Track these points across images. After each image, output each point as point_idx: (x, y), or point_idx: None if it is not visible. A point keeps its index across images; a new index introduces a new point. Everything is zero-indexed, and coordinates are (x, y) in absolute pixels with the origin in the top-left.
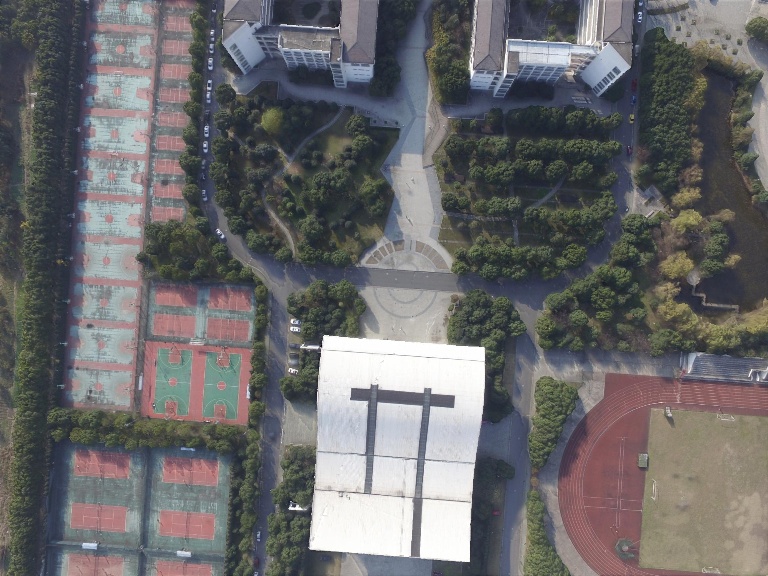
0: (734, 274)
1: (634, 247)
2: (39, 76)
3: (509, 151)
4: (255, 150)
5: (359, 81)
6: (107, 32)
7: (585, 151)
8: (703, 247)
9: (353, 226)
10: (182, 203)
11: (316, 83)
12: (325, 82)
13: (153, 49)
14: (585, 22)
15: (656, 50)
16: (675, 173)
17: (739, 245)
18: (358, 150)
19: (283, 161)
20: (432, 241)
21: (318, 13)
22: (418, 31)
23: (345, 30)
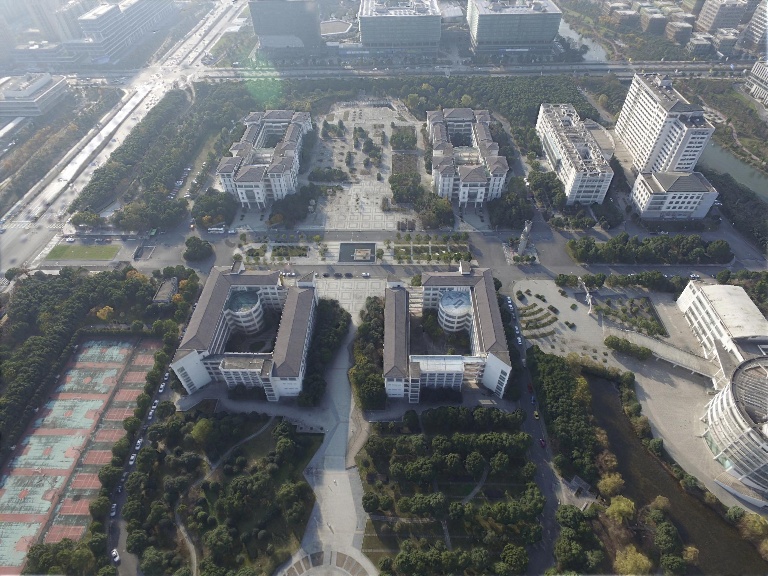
0: (706, 575)
1: (576, 543)
2: (2, 401)
3: (427, 447)
4: (179, 458)
5: (290, 395)
6: (82, 368)
7: (496, 442)
8: (653, 540)
9: (267, 537)
10: (86, 520)
11: (251, 398)
12: (259, 397)
13: (116, 379)
14: (473, 343)
15: (536, 360)
16: (590, 460)
17: (694, 538)
18: (280, 452)
19: (206, 469)
20: (355, 551)
21: (262, 348)
22: (343, 357)
23: (277, 354)
